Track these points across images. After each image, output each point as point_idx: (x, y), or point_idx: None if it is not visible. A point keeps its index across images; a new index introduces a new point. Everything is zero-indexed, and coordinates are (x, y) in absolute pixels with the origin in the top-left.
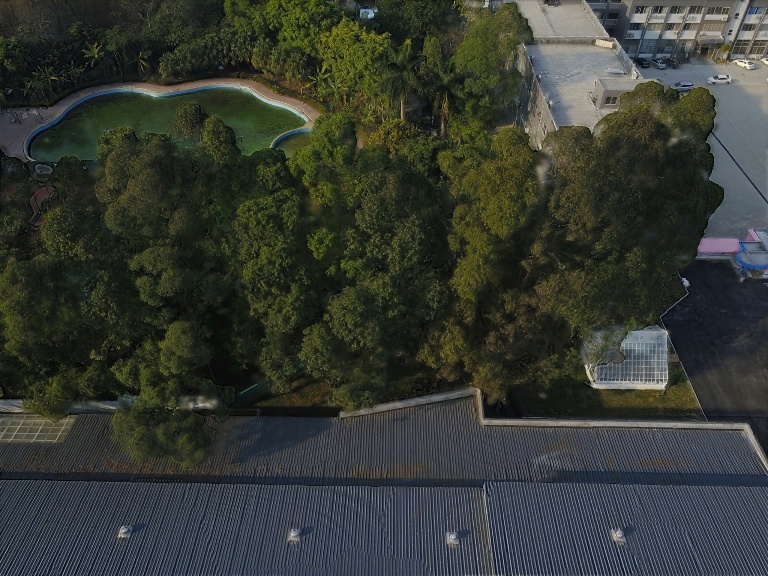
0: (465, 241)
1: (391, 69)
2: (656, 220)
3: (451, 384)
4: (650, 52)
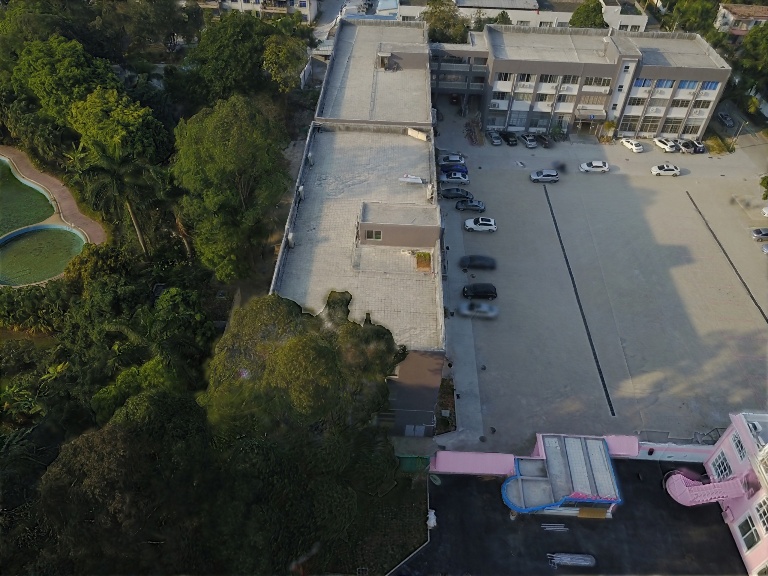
0: None
1: (94, 175)
2: None
3: None
4: (521, 125)
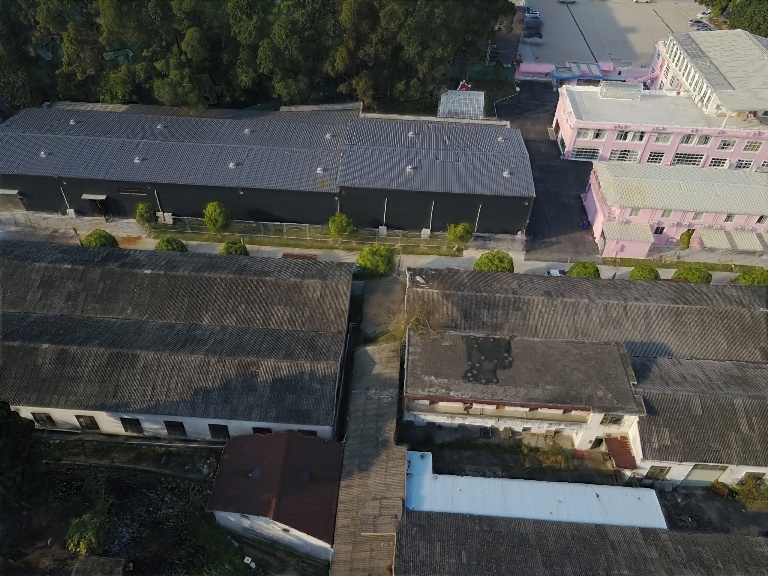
0: None
1: None
2: None
3: None
4: None
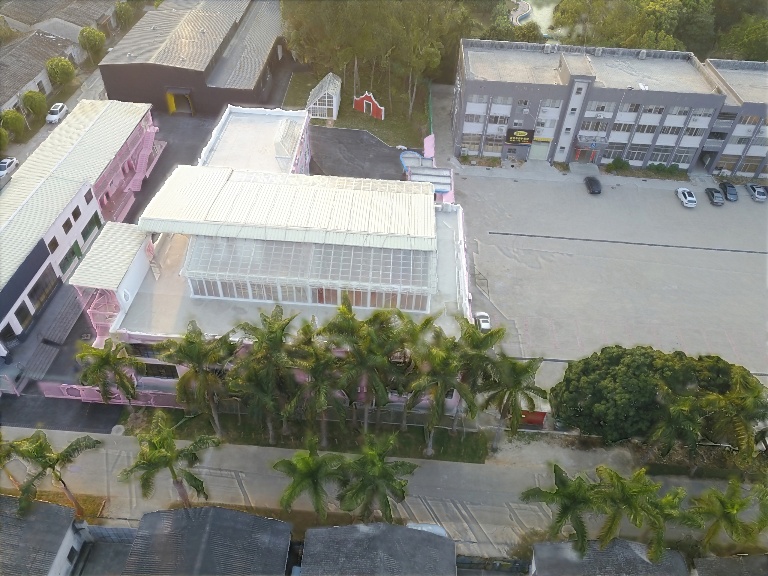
0: None
1: None
2: None
3: (322, 64)
4: None
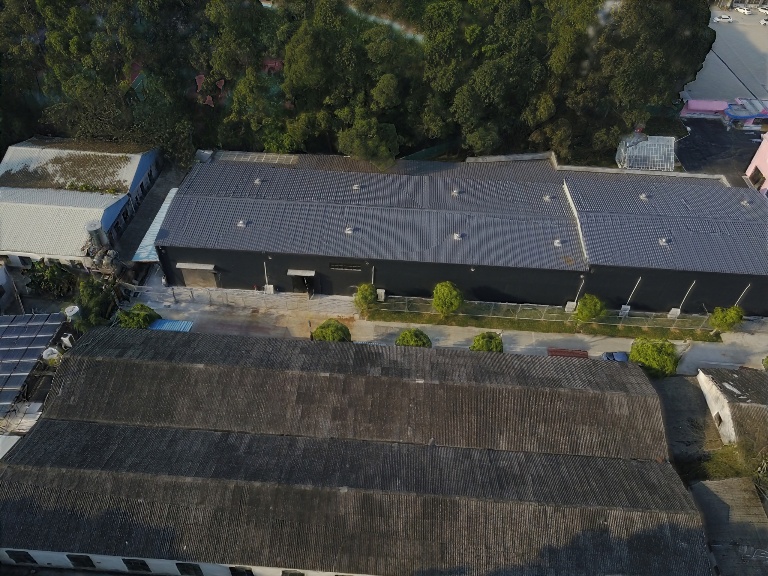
0: (559, 35)
1: None
2: (673, 36)
3: None
4: None
